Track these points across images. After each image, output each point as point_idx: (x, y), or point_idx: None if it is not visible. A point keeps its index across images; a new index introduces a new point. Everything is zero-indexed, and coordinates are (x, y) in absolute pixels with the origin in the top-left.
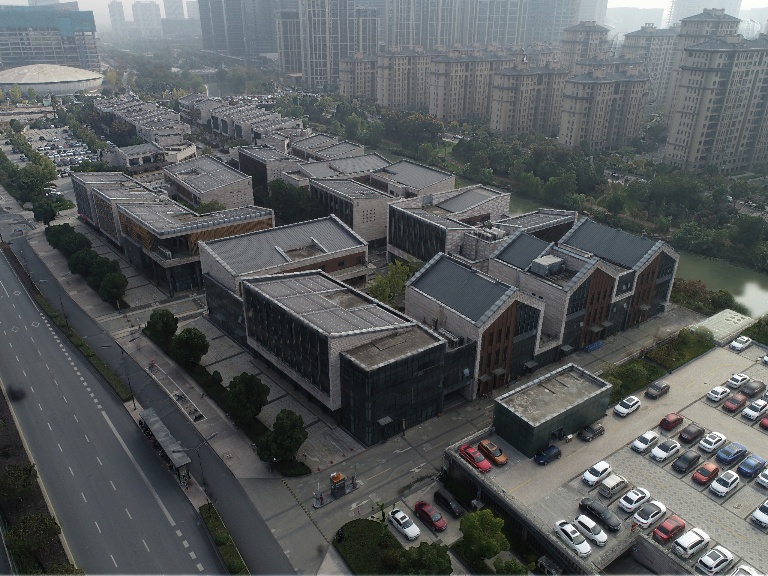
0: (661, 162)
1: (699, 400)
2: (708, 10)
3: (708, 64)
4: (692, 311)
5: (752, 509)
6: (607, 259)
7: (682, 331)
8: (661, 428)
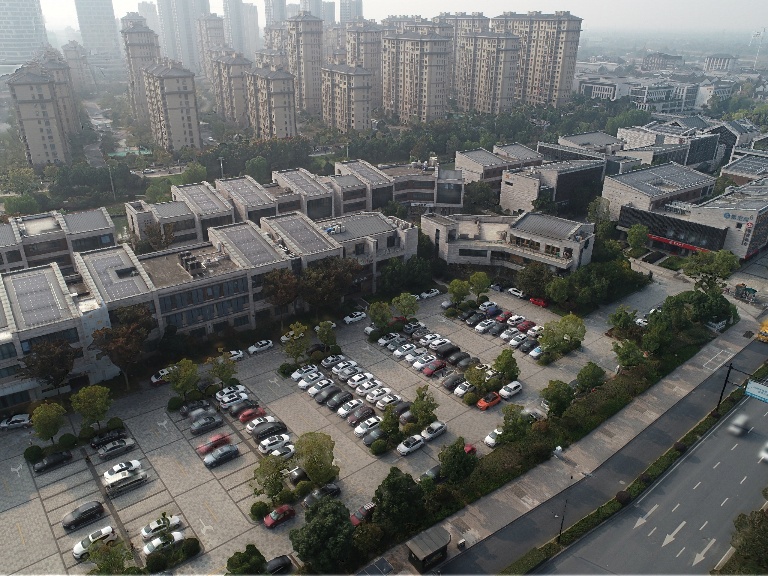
0: (412, 123)
1: None
2: (306, 12)
3: (446, 49)
4: None
5: None
6: None
7: None
8: None
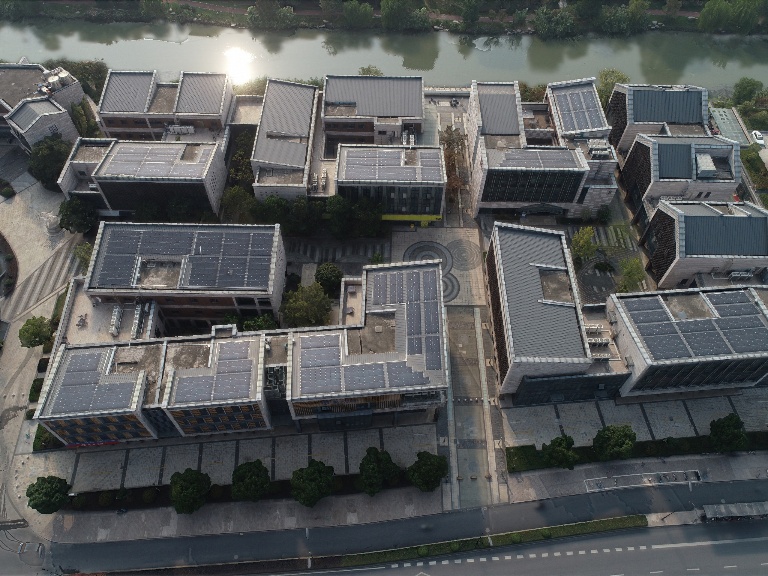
0: None
1: None
2: None
3: None
4: None
5: None
6: (677, 122)
7: (754, 156)
8: None
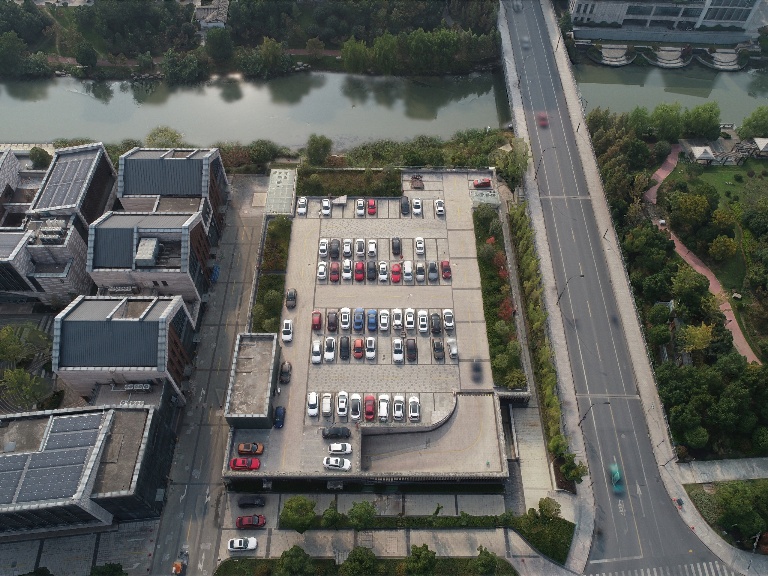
0: None
1: (316, 285)
2: None
3: None
4: (245, 176)
5: (390, 353)
6: (174, 195)
7: (269, 230)
8: (315, 331)
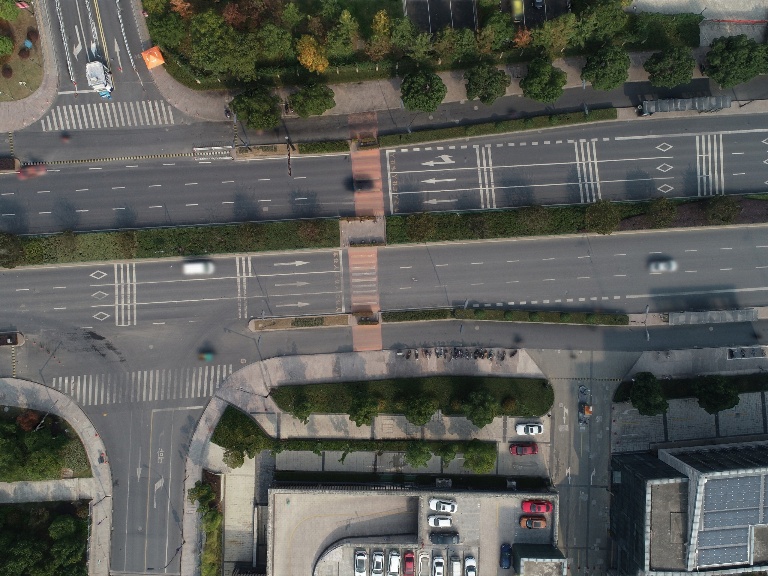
0: None
1: None
2: None
3: None
4: None
5: None
6: None
7: None
8: None
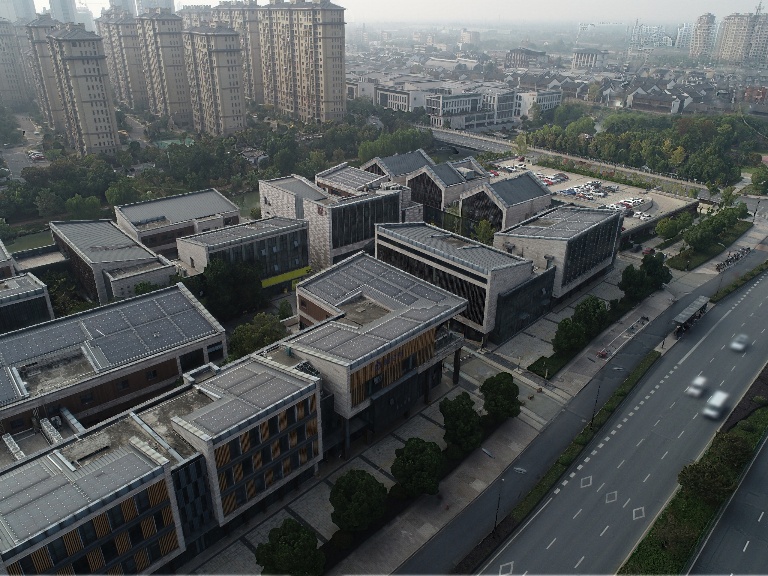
0: None
1: None
2: None
3: (98, 52)
4: None
5: None
6: None
7: None
8: None
